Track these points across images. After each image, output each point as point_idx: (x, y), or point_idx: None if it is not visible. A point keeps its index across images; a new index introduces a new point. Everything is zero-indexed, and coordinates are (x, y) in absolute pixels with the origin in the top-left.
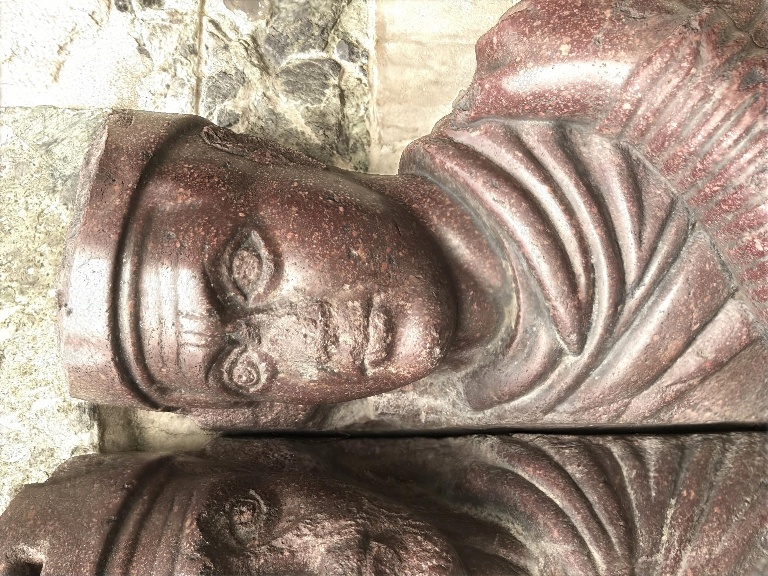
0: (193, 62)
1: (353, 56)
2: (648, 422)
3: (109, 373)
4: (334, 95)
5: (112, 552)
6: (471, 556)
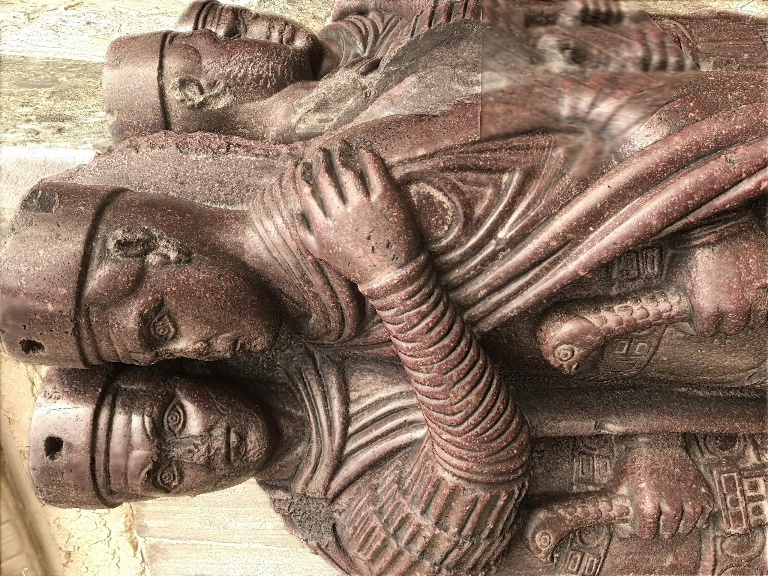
0: None
1: None
2: None
3: None
4: None
5: None
6: None
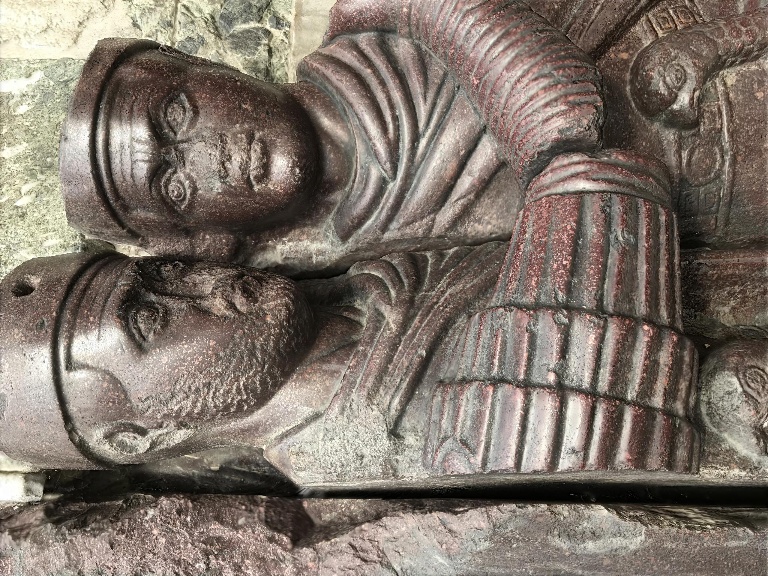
0: (169, 32)
1: (279, 25)
2: (451, 235)
3: (89, 184)
4: (264, 50)
5: (81, 276)
6: None
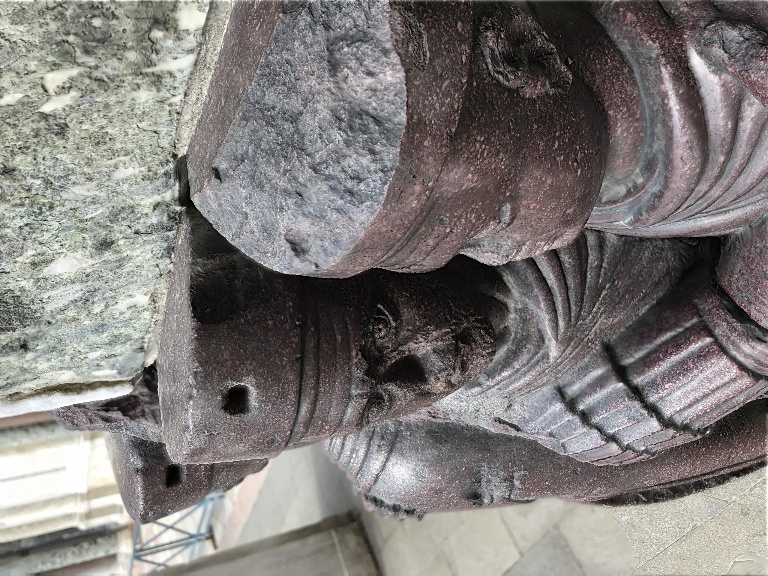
0: None
1: None
2: None
3: None
4: None
5: (304, 379)
6: (481, 301)
